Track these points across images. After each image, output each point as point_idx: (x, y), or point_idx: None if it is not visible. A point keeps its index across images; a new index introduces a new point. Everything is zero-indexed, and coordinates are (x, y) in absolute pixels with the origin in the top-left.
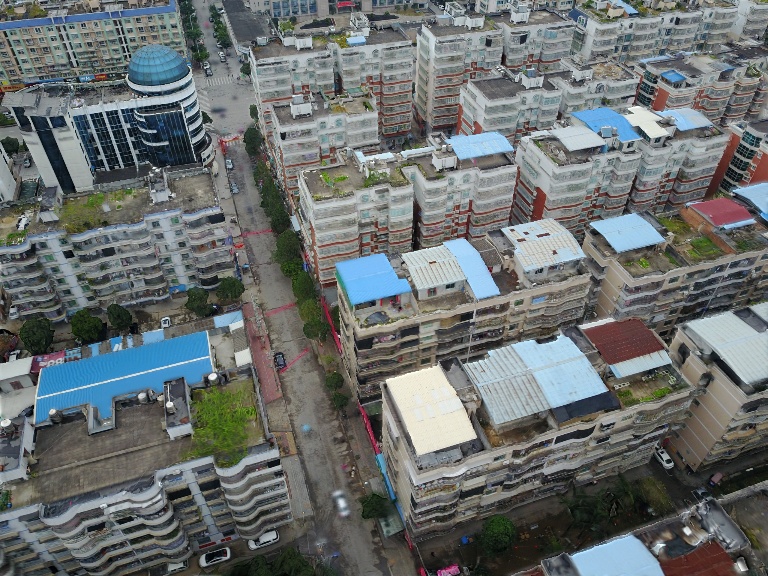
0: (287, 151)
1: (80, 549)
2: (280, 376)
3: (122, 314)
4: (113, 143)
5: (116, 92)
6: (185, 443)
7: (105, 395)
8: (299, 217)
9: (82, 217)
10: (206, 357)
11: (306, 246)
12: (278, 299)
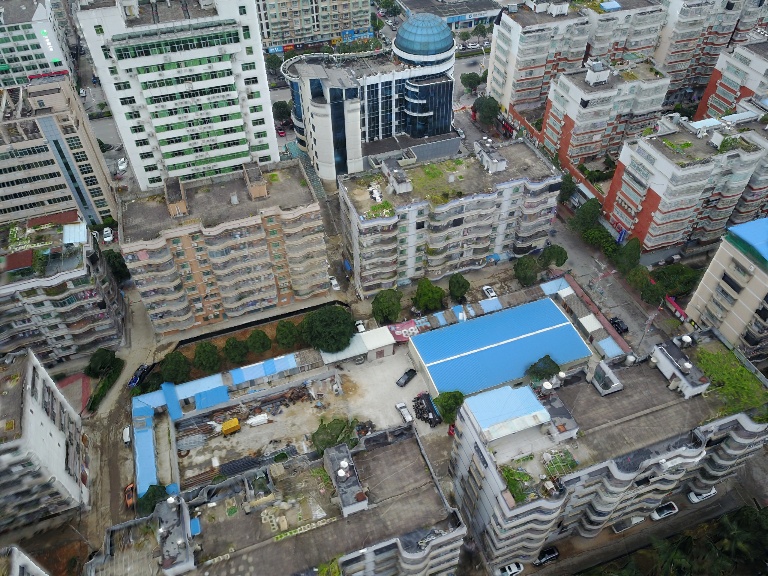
0: (583, 119)
1: (613, 503)
2: (626, 340)
3: (465, 283)
4: (379, 114)
5: (379, 62)
6: (700, 402)
7: (489, 361)
8: (592, 185)
9: (438, 188)
10: (567, 323)
11: (617, 213)
12: (583, 266)
